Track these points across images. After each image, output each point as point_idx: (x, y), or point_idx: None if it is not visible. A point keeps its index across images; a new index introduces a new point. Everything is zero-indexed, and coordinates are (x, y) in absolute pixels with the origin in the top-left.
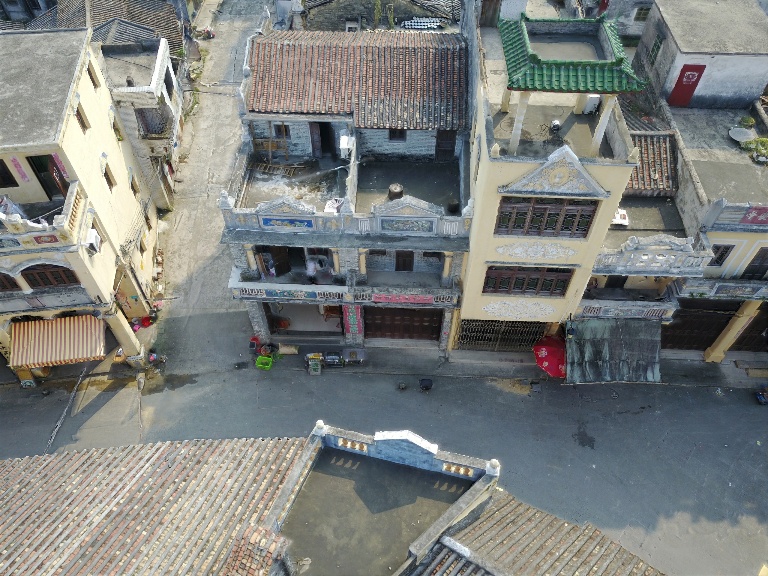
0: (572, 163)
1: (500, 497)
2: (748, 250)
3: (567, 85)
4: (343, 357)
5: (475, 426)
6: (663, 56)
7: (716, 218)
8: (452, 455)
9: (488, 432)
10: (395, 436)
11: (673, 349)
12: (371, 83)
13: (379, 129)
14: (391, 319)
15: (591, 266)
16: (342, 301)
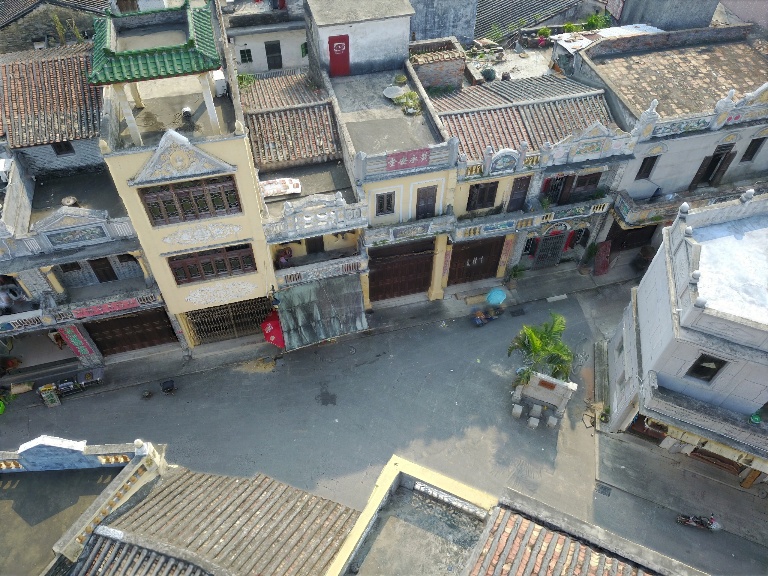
0: (184, 145)
1: (173, 474)
2: (408, 194)
3: (147, 73)
4: (78, 381)
5: (222, 414)
6: (314, 32)
7: (363, 171)
8: (102, 447)
9: (235, 416)
10: (32, 444)
11: (401, 296)
12: (22, 101)
13: (37, 146)
14: (120, 331)
15: (263, 237)
16: (43, 325)
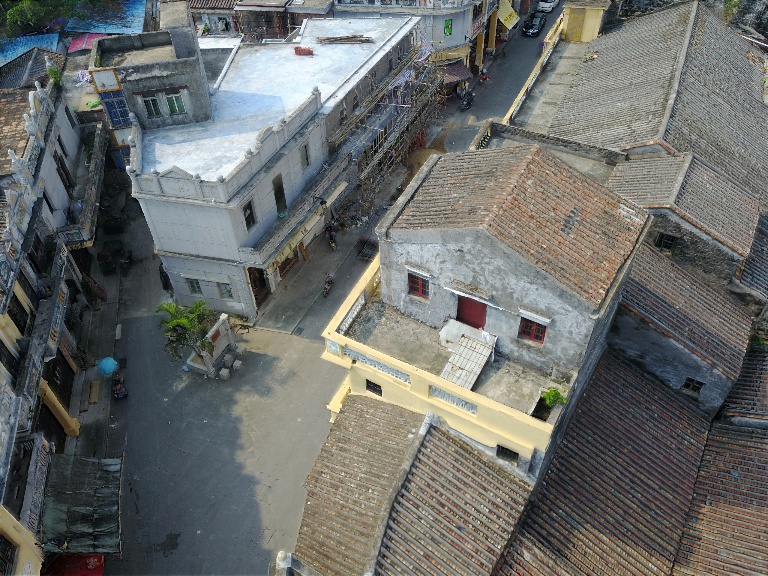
0: None
1: None
2: None
3: None
4: None
5: None
6: None
7: None
8: None
9: None
10: None
11: None
12: None
13: None
14: None
15: None
16: None
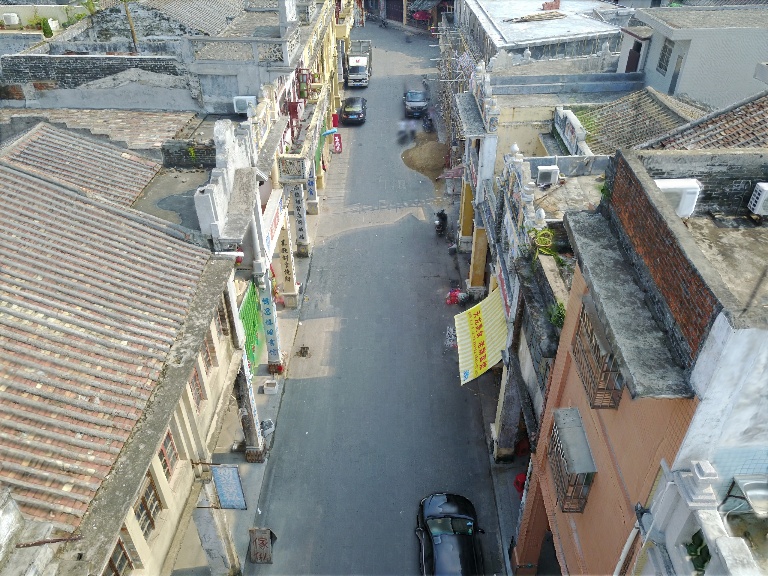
0: None
1: None
2: None
3: None
4: None
5: None
6: None
7: None
8: None
9: None
10: None
11: None
12: None
13: None
14: (393, 7)
15: None
16: None
